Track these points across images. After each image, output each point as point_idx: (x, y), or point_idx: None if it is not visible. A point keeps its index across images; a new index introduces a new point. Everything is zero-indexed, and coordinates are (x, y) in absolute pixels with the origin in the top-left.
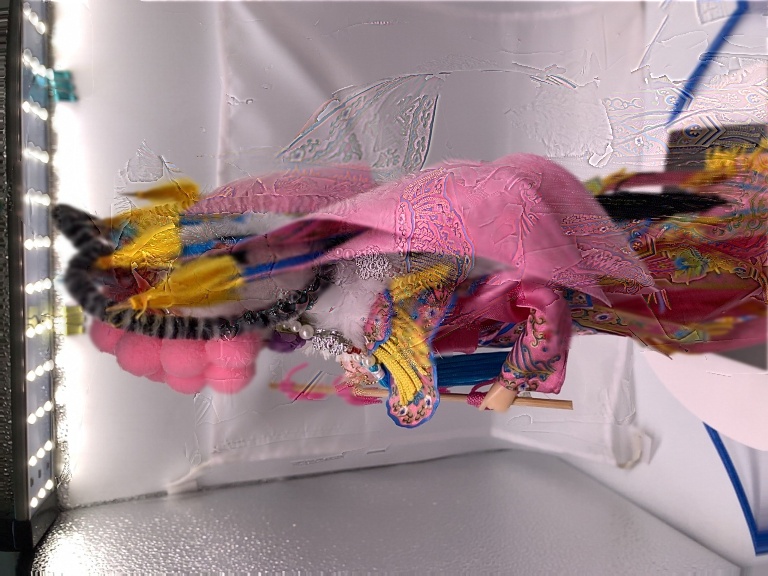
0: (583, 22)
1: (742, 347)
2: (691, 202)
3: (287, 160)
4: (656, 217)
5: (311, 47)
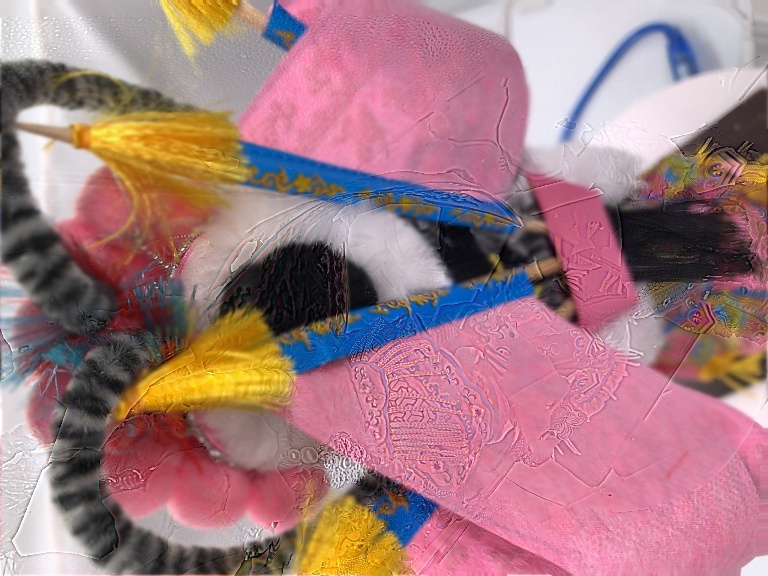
0: (377, 216)
1: (666, 468)
2: (724, 256)
3: (212, 322)
4: (705, 278)
5: (101, 272)
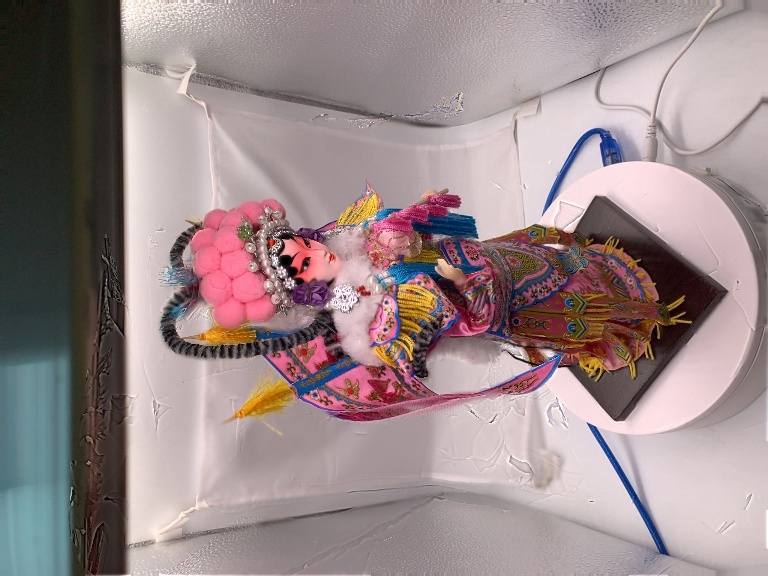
0: None
1: (710, 231)
2: None
3: None
4: None
5: None
